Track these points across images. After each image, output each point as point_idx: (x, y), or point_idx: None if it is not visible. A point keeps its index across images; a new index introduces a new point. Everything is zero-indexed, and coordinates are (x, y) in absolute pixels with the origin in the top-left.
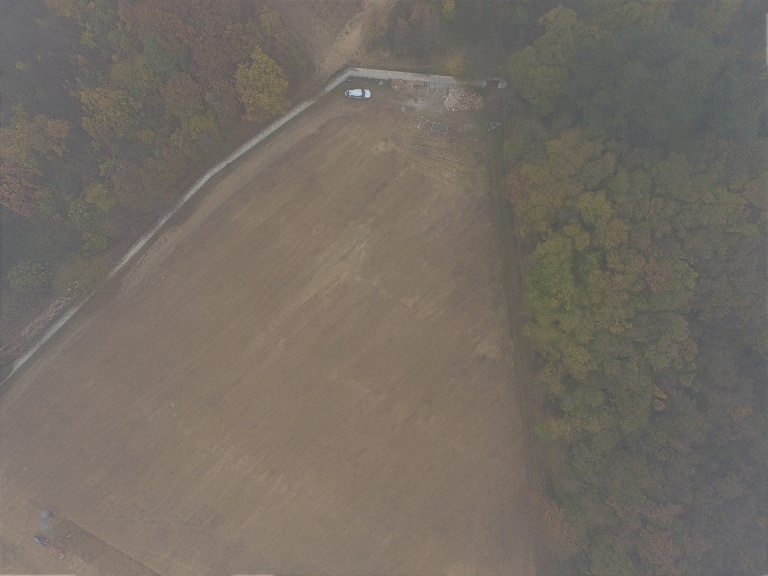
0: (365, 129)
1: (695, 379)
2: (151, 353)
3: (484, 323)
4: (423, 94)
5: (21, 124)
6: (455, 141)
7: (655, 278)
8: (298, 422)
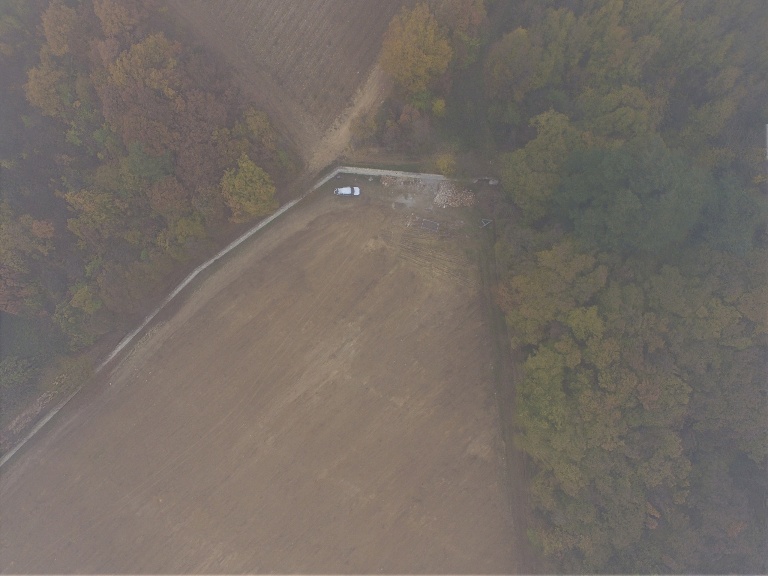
0: (354, 226)
1: (689, 496)
2: (139, 448)
3: (475, 423)
4: (413, 190)
5: (6, 224)
6: (446, 239)
7: (648, 397)
8: (287, 520)
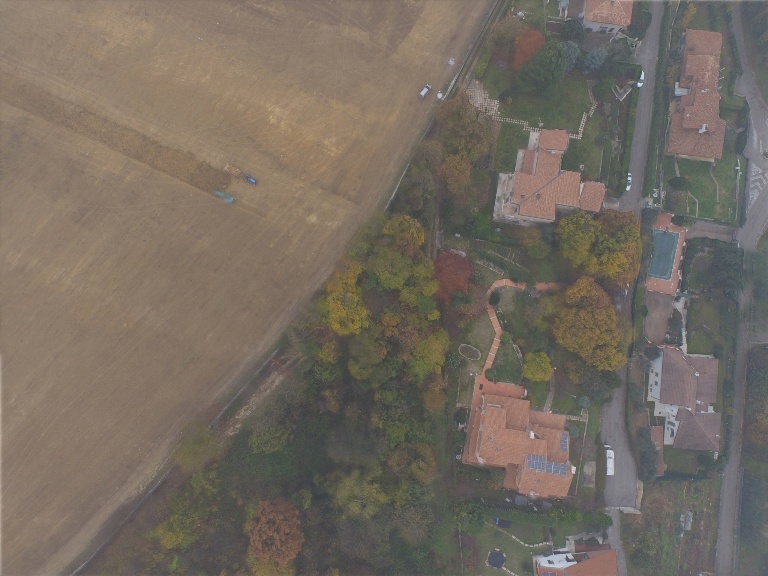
0: None
1: None
2: (149, 373)
3: None
4: None
5: None
6: None
7: None
8: None
